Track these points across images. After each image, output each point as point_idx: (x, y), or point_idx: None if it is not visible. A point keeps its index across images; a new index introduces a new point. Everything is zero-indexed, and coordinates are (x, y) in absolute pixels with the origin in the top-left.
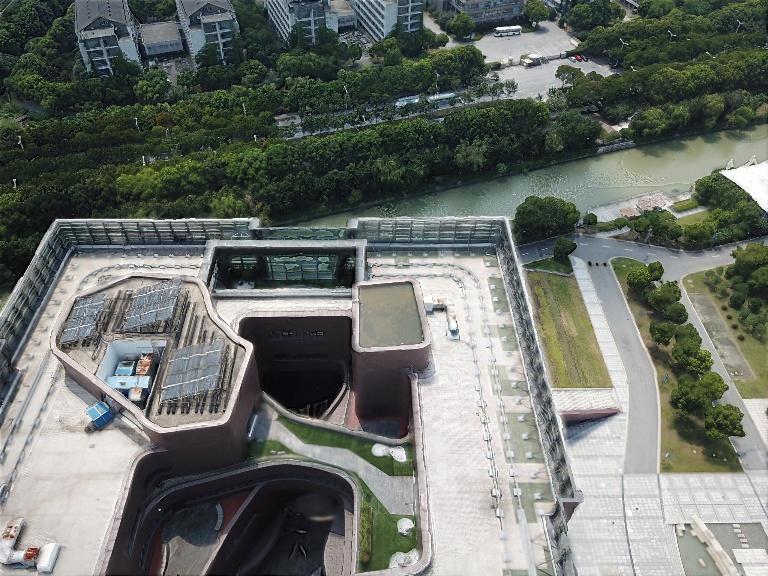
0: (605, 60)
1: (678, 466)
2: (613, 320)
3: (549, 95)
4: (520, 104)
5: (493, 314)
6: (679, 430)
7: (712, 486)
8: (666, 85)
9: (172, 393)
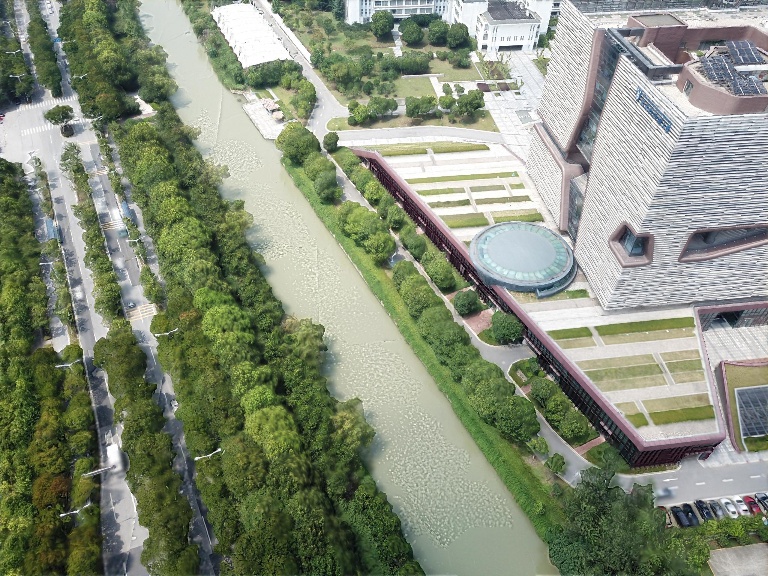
0: (9, 105)
1: (494, 127)
2: (390, 136)
3: (98, 129)
4: (146, 130)
5: (614, 18)
6: (471, 123)
7: (501, 120)
8: (123, 64)
9: (760, 57)
